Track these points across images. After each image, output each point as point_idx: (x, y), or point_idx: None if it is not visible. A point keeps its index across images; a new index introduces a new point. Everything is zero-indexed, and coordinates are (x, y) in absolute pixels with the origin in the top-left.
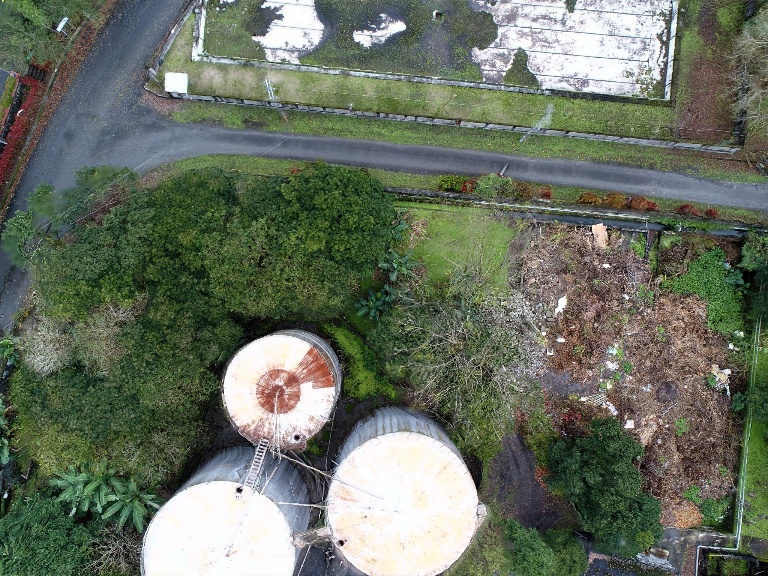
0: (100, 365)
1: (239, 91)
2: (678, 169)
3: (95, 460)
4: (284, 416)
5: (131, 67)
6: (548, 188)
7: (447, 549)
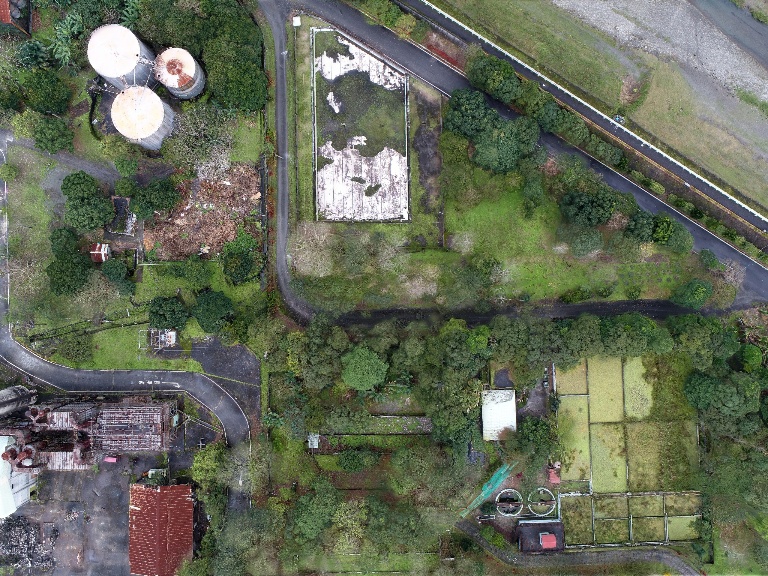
0: (177, 3)
1: (300, 47)
2: (290, 228)
3: (143, 5)
4: (166, 70)
5: (305, 3)
6: (276, 176)
7: (125, 129)
